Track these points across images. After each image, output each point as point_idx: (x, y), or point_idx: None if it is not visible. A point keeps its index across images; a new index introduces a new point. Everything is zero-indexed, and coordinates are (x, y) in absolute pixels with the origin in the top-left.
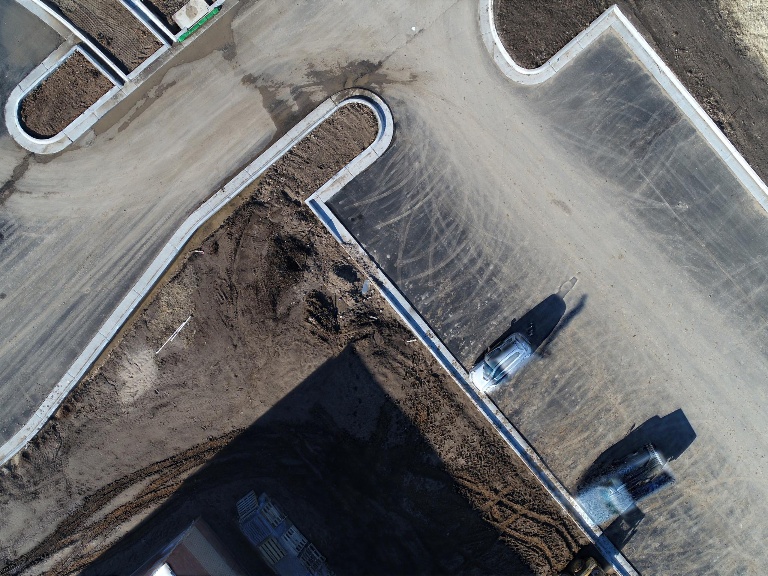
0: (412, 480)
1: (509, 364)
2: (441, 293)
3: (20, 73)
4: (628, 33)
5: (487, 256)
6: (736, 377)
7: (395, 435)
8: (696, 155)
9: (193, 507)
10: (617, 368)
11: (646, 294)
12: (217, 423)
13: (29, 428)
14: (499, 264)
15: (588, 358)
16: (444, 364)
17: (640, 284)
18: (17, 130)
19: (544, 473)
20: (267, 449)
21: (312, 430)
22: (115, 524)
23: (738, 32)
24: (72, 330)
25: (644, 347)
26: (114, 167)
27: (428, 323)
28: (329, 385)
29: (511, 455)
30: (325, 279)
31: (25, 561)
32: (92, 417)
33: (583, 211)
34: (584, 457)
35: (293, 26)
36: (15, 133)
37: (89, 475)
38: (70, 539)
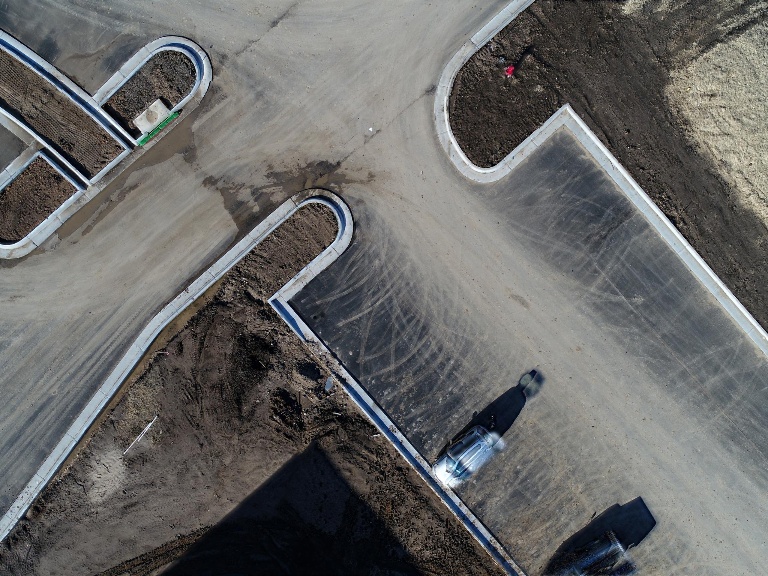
0: (378, 573)
1: (471, 456)
2: (403, 388)
3: None
4: (581, 131)
5: (448, 351)
6: (694, 465)
7: (360, 529)
8: (650, 249)
9: None
10: (577, 458)
11: (604, 385)
12: (185, 521)
13: None
14: (460, 358)
15: (549, 449)
16: (407, 458)
17: (598, 376)
18: None
19: (507, 563)
20: (235, 546)
21: (279, 526)
22: None
23: (688, 129)
24: (40, 432)
25: (603, 437)
26: (79, 270)
27: (391, 418)
28: (294, 481)
29: (475, 545)
30: (289, 377)
31: None
32: (62, 517)
33: (541, 305)
34: (546, 546)
35: (253, 128)
36: None
37: (60, 575)
38: None
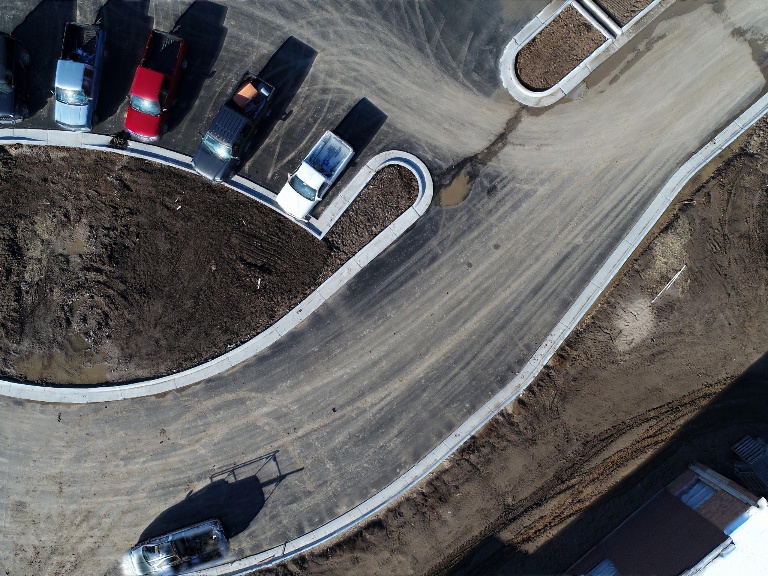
0: None
1: None
2: None
3: (515, 27)
4: None
5: None
6: None
7: None
8: None
9: (688, 452)
10: None
11: None
12: (711, 370)
13: (523, 376)
14: None
15: None
16: None
17: None
18: (512, 83)
19: None
20: (760, 395)
21: None
22: (611, 469)
23: None
24: (565, 280)
25: None
26: (606, 119)
27: None
28: None
29: None
30: None
31: (522, 506)
32: (587, 365)
33: None
34: None
35: None
36: (510, 86)
37: (586, 421)
38: (566, 484)
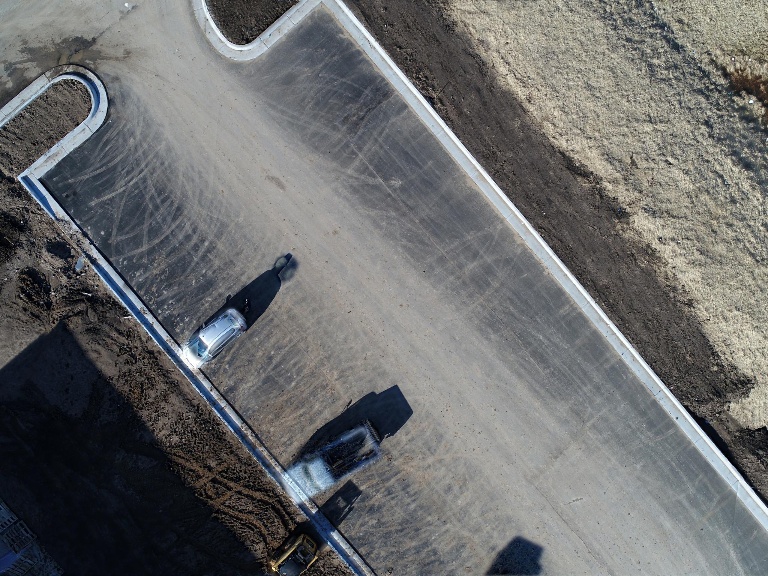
0: (124, 457)
1: (224, 340)
2: (156, 269)
3: None
4: (339, 9)
5: (202, 232)
6: (451, 353)
7: (108, 412)
8: (408, 131)
9: None
10: (333, 344)
11: (361, 270)
12: None
13: None
14: (214, 240)
15: (304, 334)
16: (157, 340)
17: (354, 260)
18: None
19: (259, 450)
20: None
21: (24, 407)
22: None
23: (446, 7)
24: None
25: (359, 323)
26: None
27: (142, 299)
28: (41, 362)
29: (227, 432)
30: (38, 255)
31: None
32: None
33: (297, 187)
34: (300, 434)
35: (7, 2)
36: None
37: None
38: None
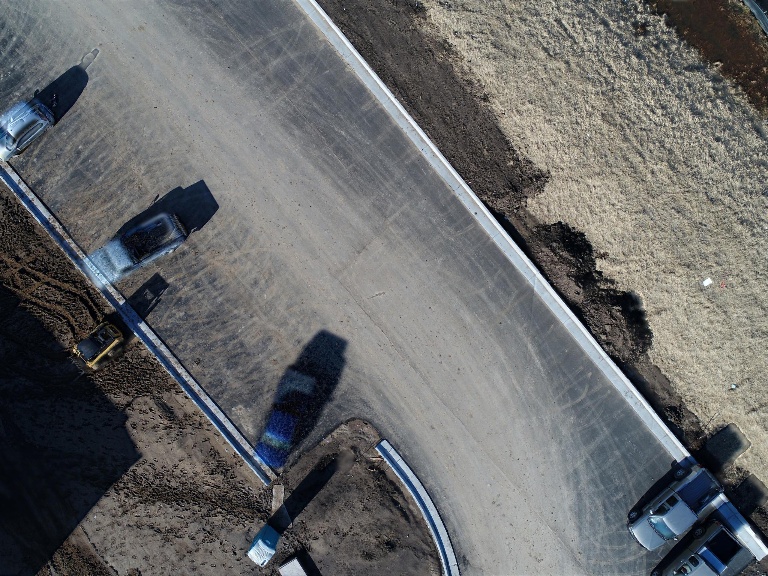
0: None
1: (32, 135)
2: None
3: None
4: None
5: (10, 28)
6: (256, 148)
7: None
8: None
9: None
10: (140, 139)
11: (166, 66)
12: None
13: None
14: (22, 36)
15: (111, 129)
16: None
17: (160, 56)
18: None
19: (66, 242)
20: None
21: None
22: None
23: None
24: None
25: (166, 118)
26: None
27: None
28: None
29: (35, 225)
30: None
31: None
32: None
33: None
34: (107, 227)
35: None
36: None
37: None
38: None
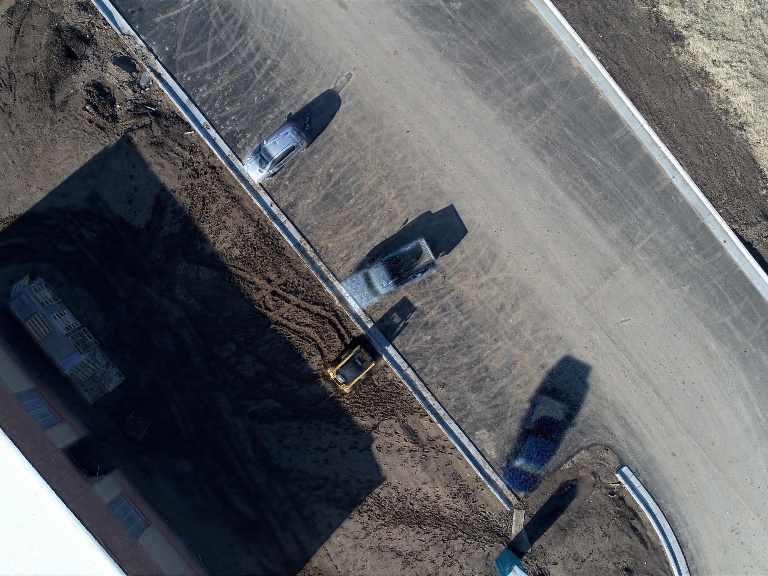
0: (186, 268)
1: (285, 157)
2: (219, 86)
3: None
4: None
5: (265, 51)
6: (507, 174)
7: (170, 224)
8: None
9: None
10: (391, 163)
11: (420, 90)
12: None
13: None
14: (276, 59)
15: (362, 153)
16: (219, 154)
17: (414, 80)
18: None
19: (317, 264)
20: (43, 234)
21: (88, 217)
22: None
23: None
24: None
25: (417, 143)
26: None
27: (205, 115)
28: (105, 173)
29: (286, 247)
30: (103, 69)
31: None
32: None
33: (359, 7)
34: (357, 250)
35: None
36: None
37: None
38: None
